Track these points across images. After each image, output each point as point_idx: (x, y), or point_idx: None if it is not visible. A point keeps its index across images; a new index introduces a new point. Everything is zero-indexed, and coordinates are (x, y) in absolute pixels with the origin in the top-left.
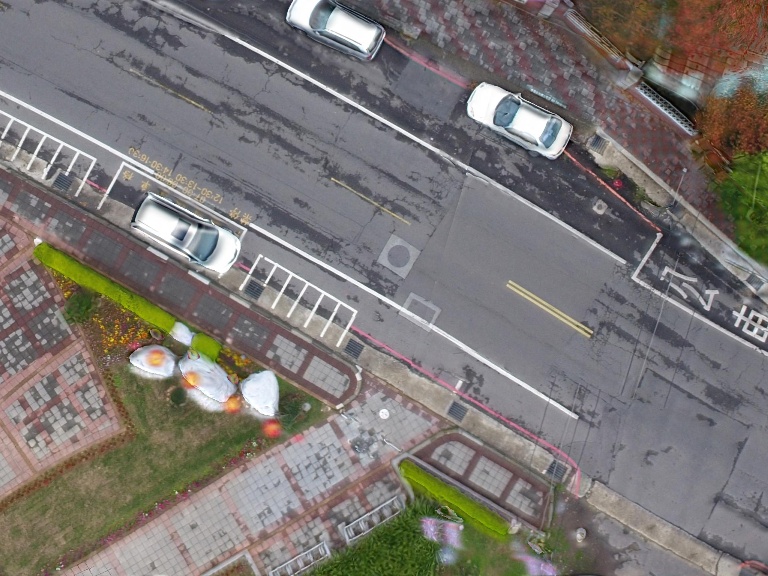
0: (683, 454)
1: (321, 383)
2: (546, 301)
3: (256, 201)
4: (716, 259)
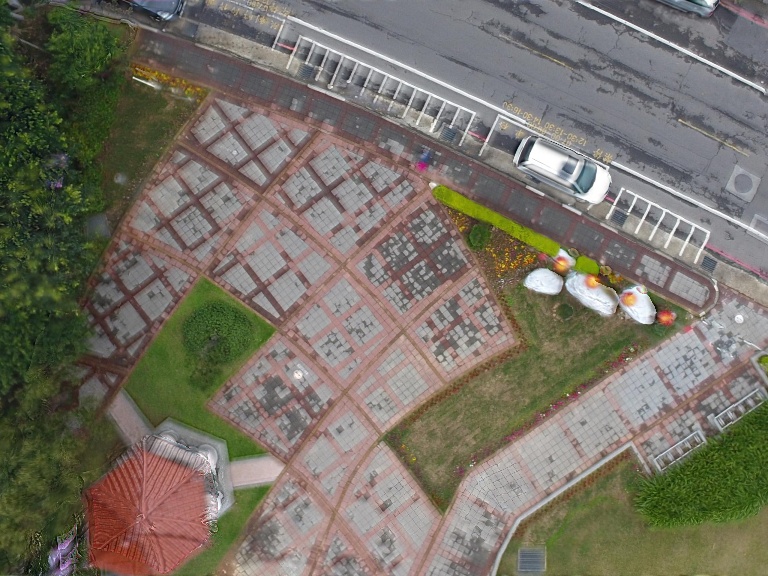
0: None
1: (686, 295)
2: None
3: (616, 142)
4: None
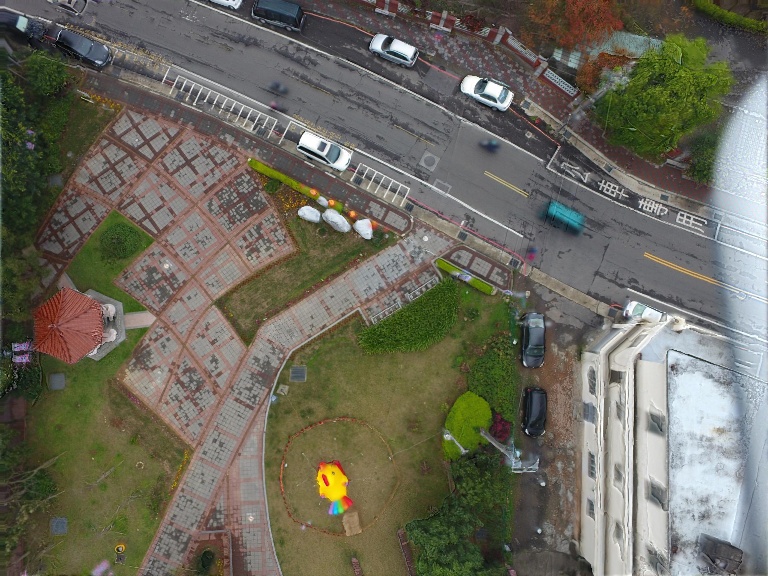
0: (577, 253)
1: (393, 224)
2: (504, 180)
3: (357, 137)
4: (588, 158)
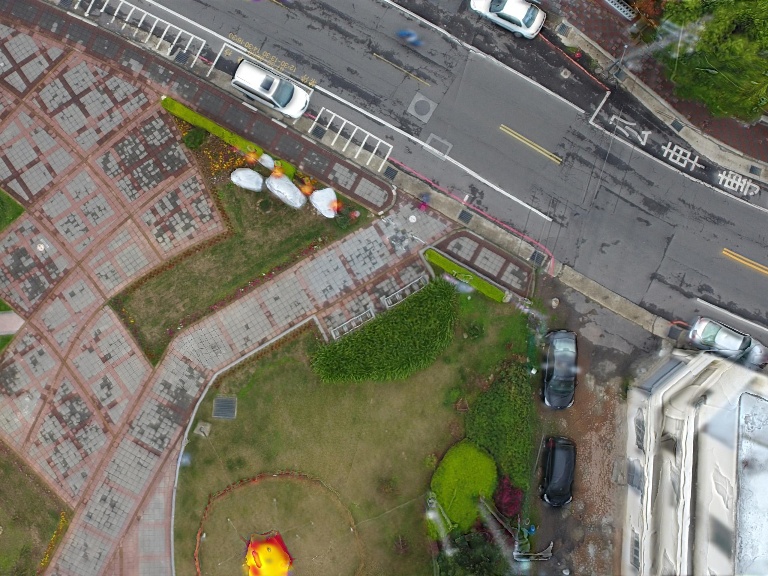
0: (628, 246)
1: (368, 196)
2: (528, 138)
3: (320, 70)
4: (649, 110)
